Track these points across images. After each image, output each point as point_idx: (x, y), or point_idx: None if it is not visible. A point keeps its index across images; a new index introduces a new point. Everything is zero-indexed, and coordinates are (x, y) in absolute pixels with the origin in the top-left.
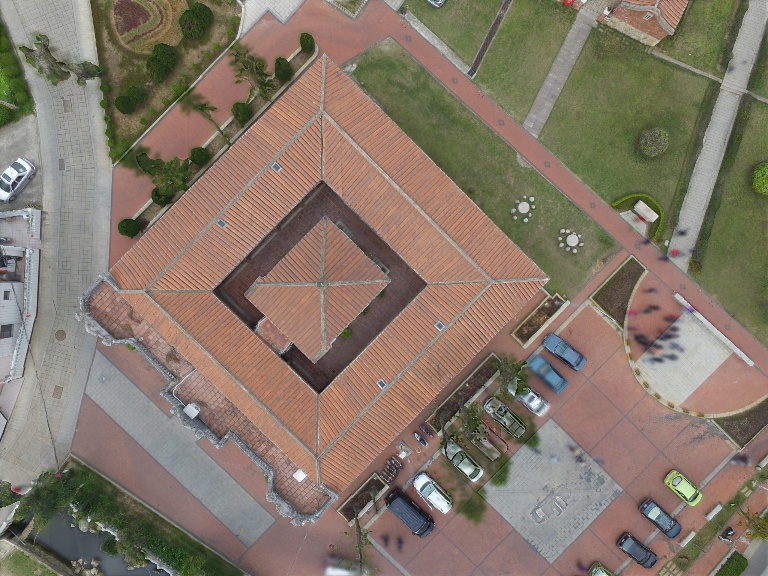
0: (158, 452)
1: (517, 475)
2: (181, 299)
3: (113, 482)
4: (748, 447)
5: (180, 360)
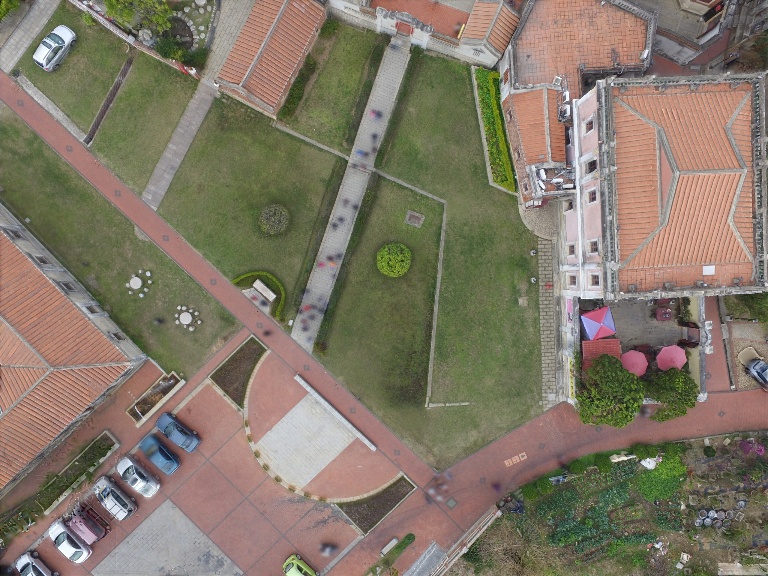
0: None
1: (132, 556)
2: None
3: None
4: (373, 533)
5: None
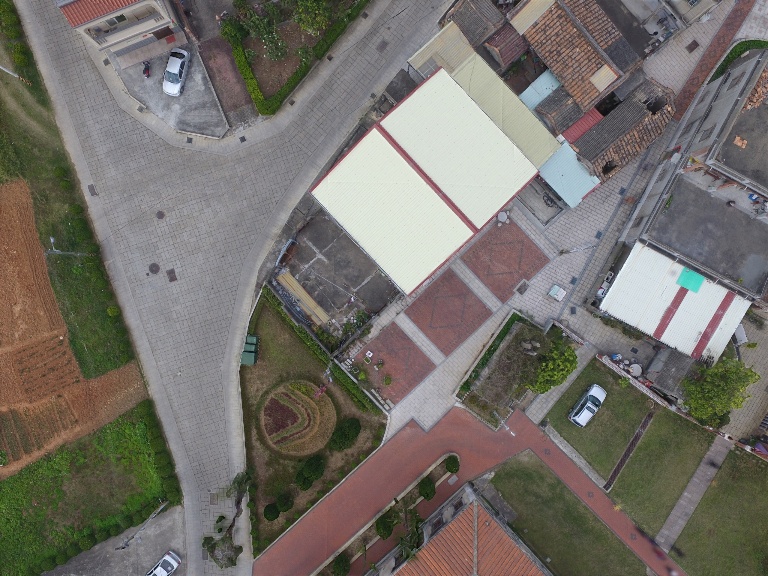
0: None
1: None
2: None
3: None
4: None
5: None
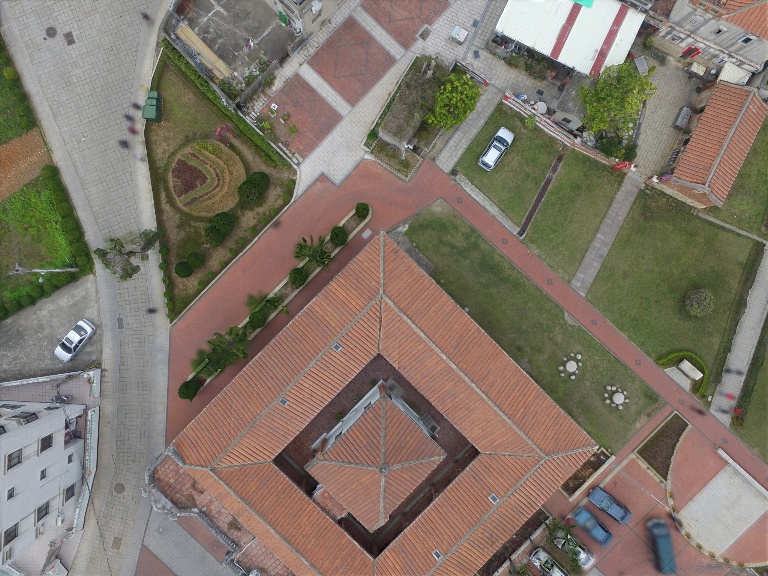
0: None
1: None
2: (243, 473)
3: None
4: None
5: (241, 529)
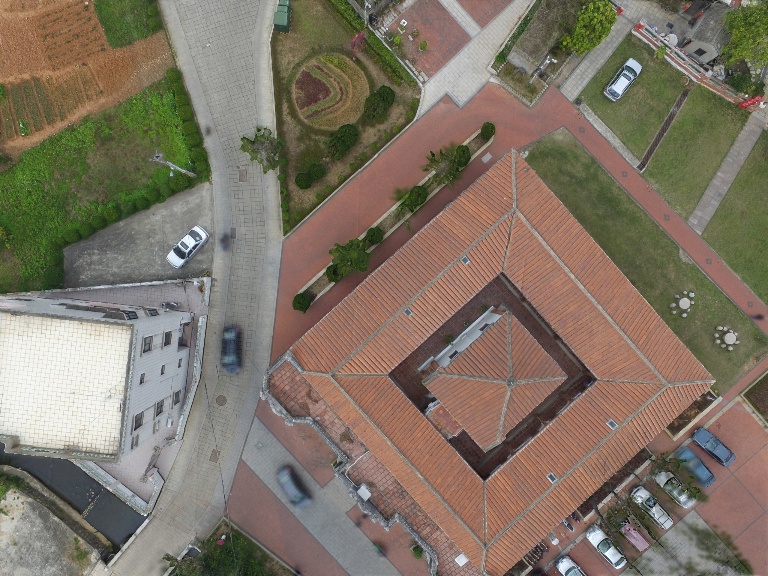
0: (308, 520)
1: (656, 563)
2: (361, 383)
3: (263, 547)
4: None
5: (354, 441)
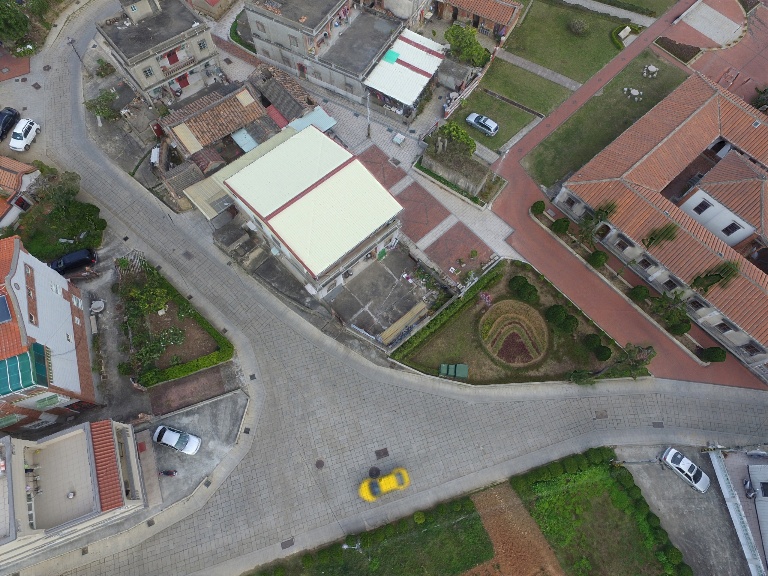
0: None
1: None
2: None
3: None
4: None
5: None
